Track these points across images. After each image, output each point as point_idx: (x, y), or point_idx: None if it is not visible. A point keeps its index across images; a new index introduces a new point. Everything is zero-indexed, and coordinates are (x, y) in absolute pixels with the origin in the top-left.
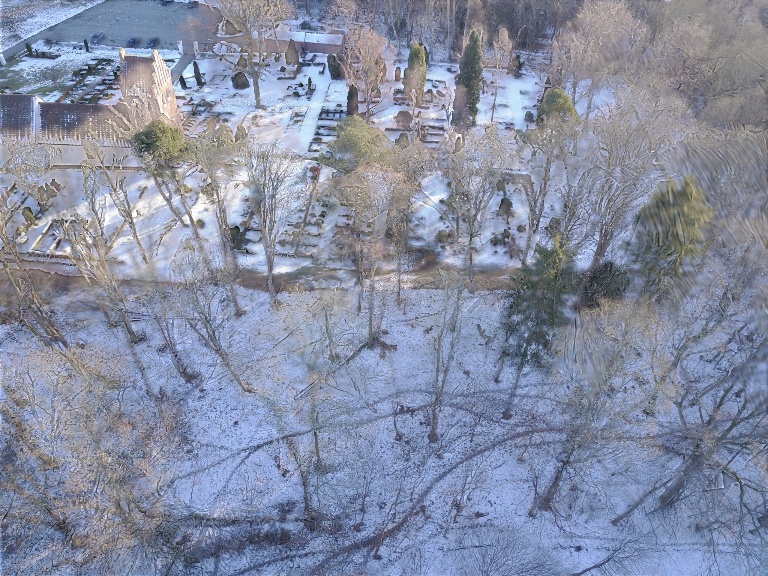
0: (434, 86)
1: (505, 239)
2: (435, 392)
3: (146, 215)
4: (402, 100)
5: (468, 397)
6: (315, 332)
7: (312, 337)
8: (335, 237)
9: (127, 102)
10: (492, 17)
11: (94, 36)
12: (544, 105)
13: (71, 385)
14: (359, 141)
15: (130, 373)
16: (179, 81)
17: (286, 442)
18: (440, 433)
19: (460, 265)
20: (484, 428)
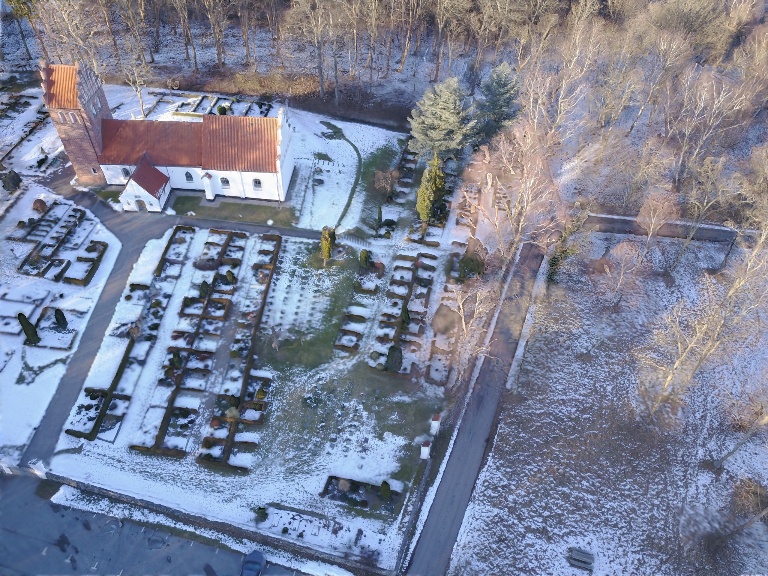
0: None
1: None
2: None
3: None
4: None
5: None
6: None
7: None
8: None
9: None
10: None
11: (253, 569)
12: None
13: None
14: None
15: None
16: None
17: None
18: None
19: None
20: None
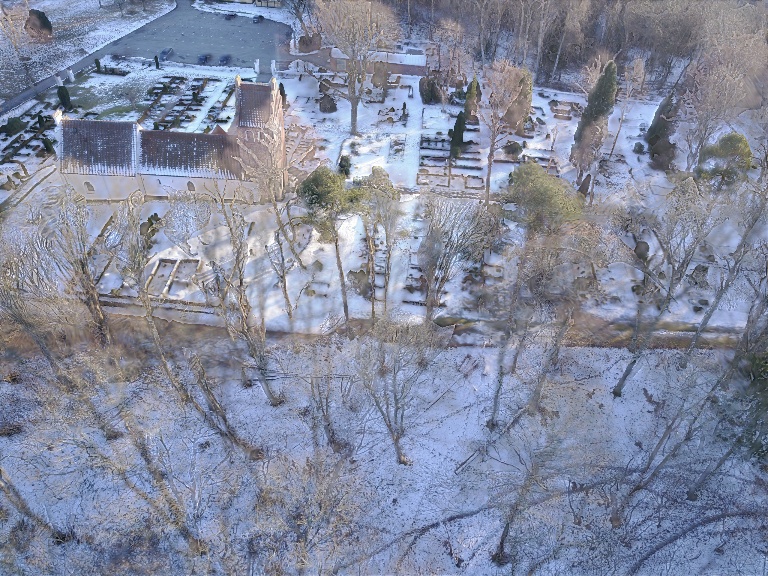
0: (531, 113)
1: None
2: (607, 466)
3: (258, 255)
4: (503, 128)
5: (644, 473)
6: (468, 395)
7: (465, 401)
8: (466, 283)
9: (240, 133)
10: (589, 41)
11: (163, 52)
12: (719, 149)
13: (210, 455)
14: (556, 195)
15: (272, 441)
16: None
17: (454, 525)
18: (622, 516)
19: (606, 317)
20: (669, 510)
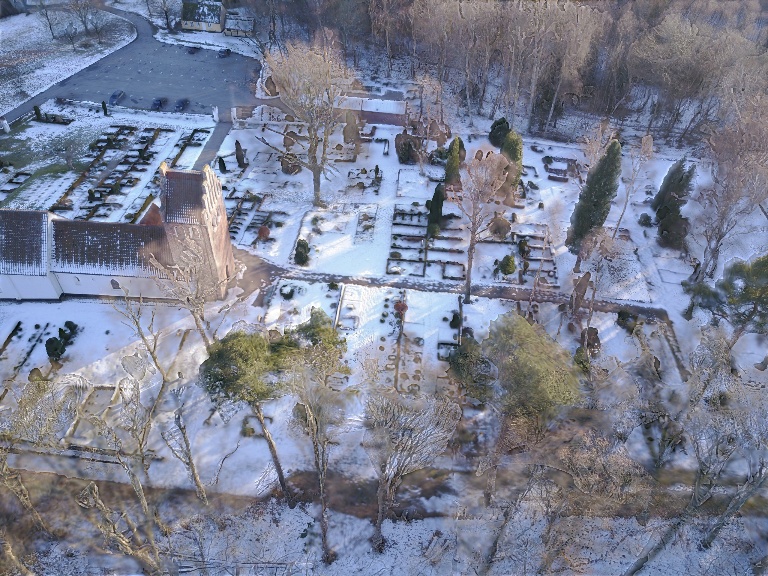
0: (523, 174)
1: (660, 419)
2: None
3: (190, 376)
4: None
5: None
6: None
7: None
8: None
9: (167, 228)
10: (588, 89)
11: (113, 95)
12: (751, 275)
13: None
14: (544, 382)
15: None
16: (217, 161)
17: None
18: None
19: None
20: None
